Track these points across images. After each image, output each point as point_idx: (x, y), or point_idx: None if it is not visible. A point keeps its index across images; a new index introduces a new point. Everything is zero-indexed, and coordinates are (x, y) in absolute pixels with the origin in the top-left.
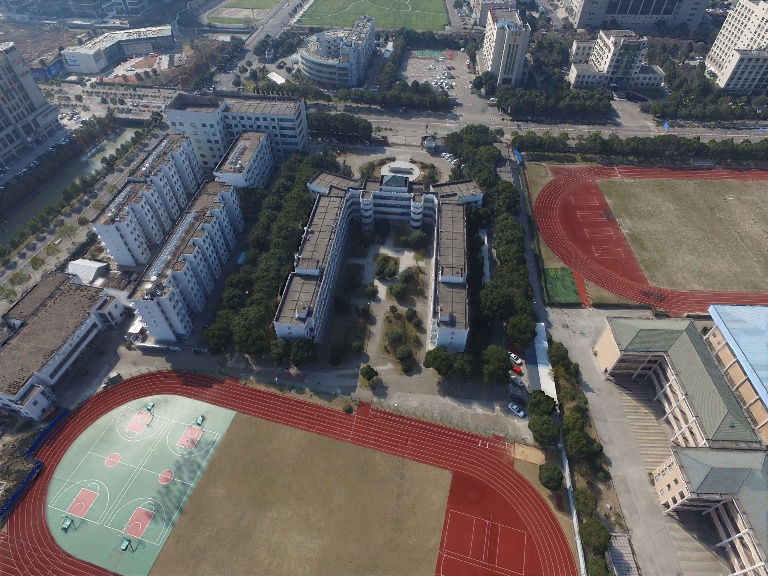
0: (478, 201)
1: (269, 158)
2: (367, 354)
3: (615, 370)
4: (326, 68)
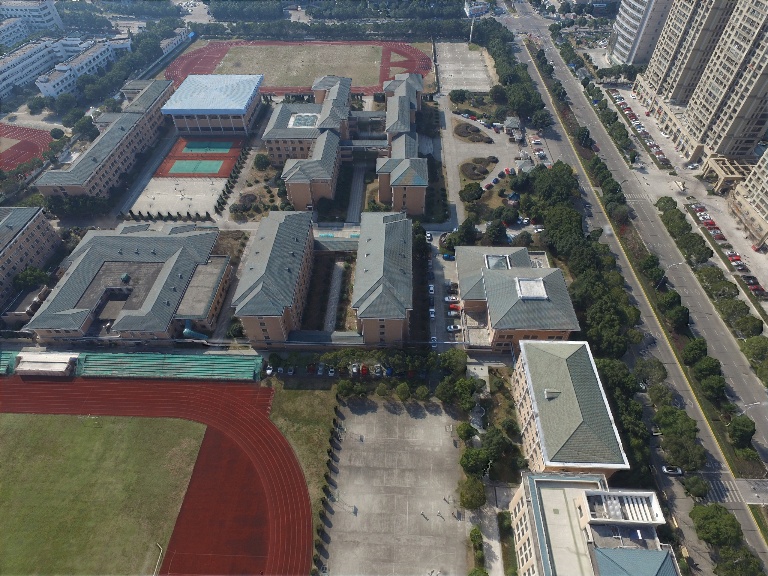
0: (127, 48)
1: None
2: (18, 109)
3: None
4: None
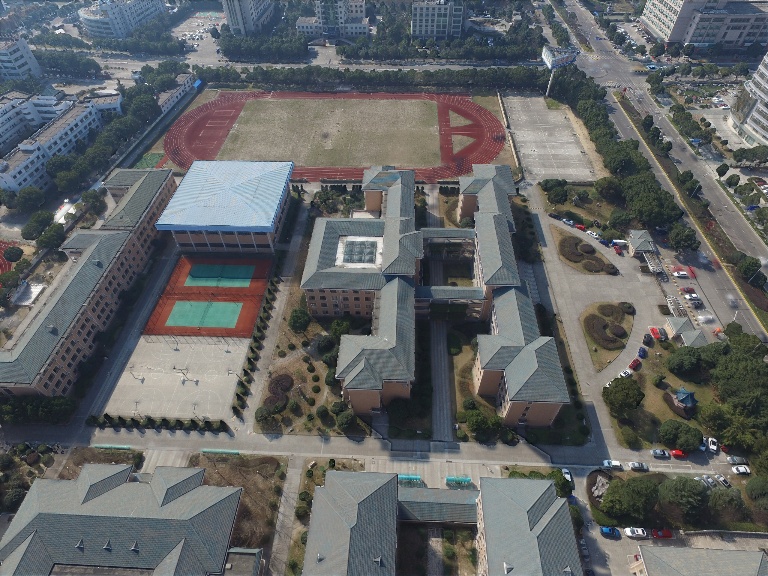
0: (116, 108)
1: None
2: None
3: None
4: (93, 23)
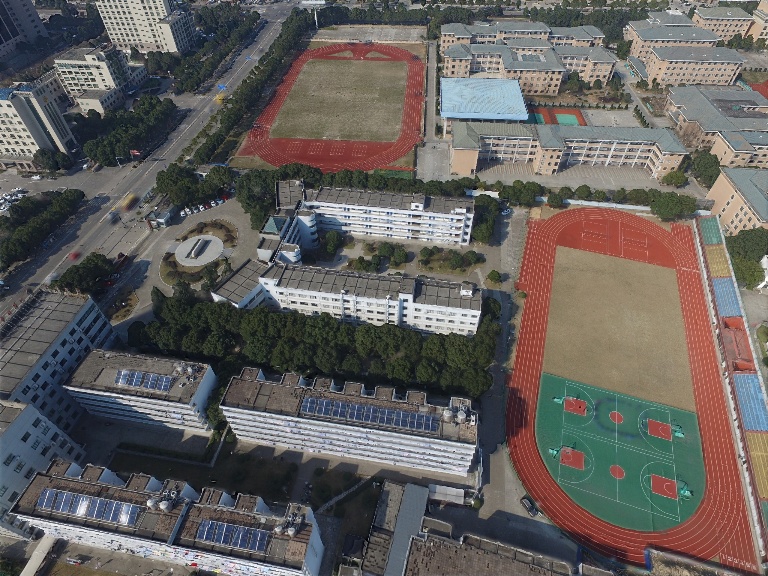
0: None
1: None
2: None
3: None
4: None
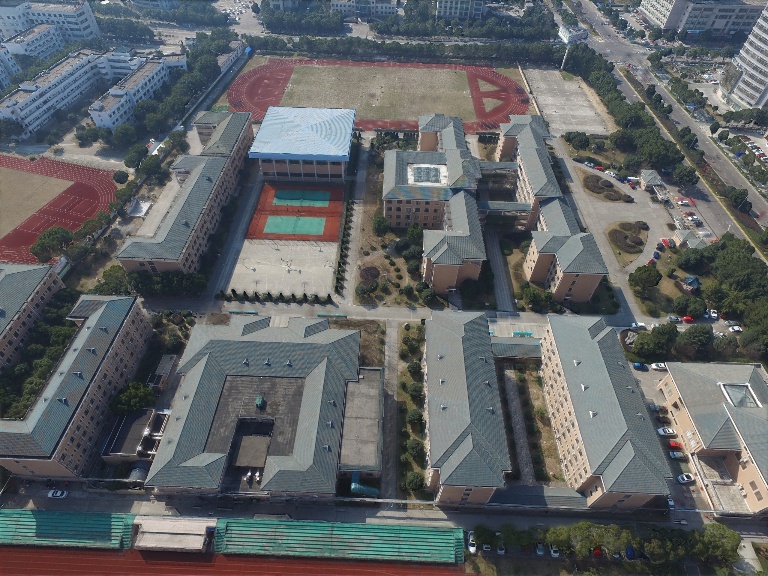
0: (183, 66)
1: (61, 45)
2: (63, 139)
3: (203, 143)
4: None
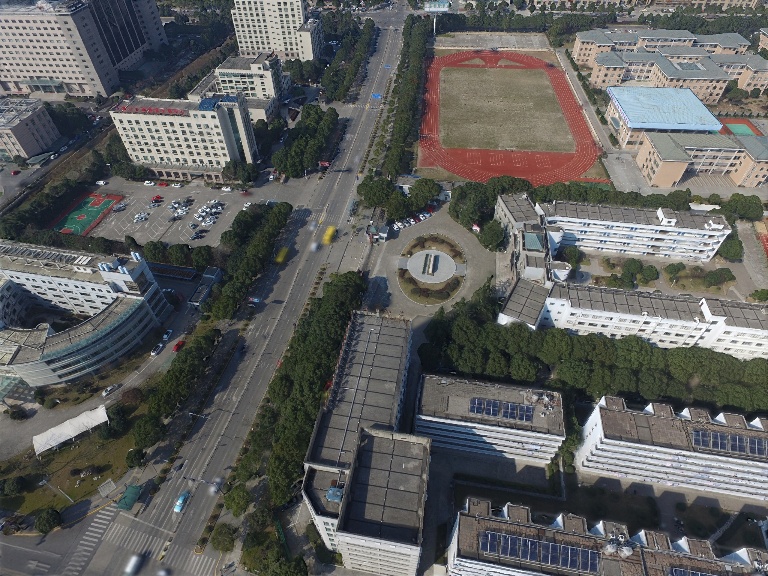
0: None
1: None
2: None
3: None
4: (131, 321)
